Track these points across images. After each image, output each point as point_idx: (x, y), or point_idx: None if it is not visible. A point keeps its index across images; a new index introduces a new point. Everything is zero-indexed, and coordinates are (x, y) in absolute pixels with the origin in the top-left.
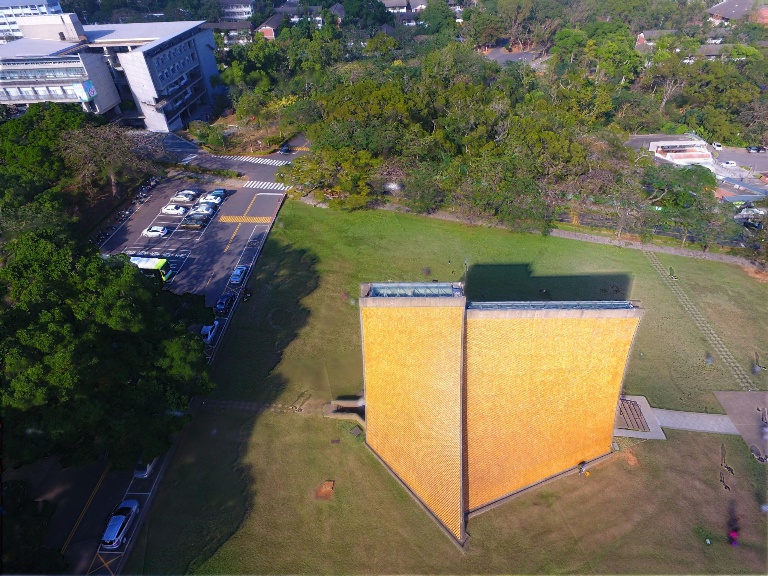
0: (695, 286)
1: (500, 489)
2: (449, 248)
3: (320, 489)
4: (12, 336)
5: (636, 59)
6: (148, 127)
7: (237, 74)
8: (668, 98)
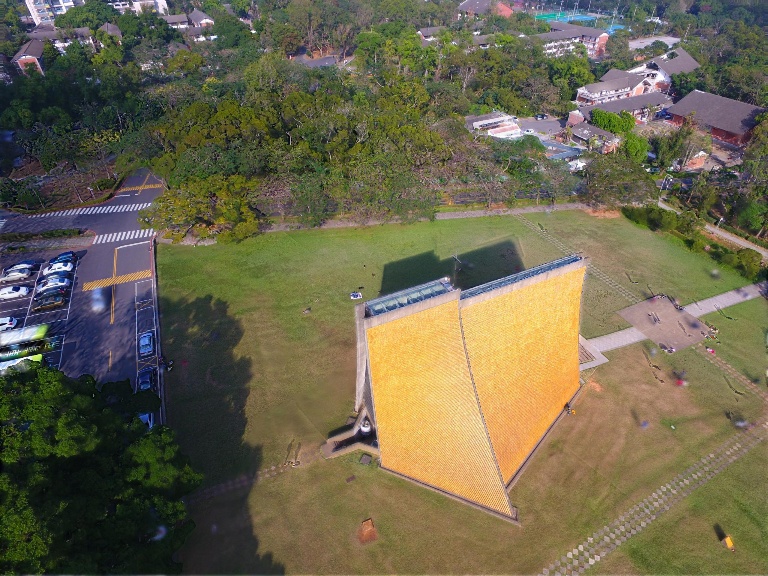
0: (562, 233)
1: (520, 455)
2: (357, 253)
3: (361, 533)
4: None
5: (433, 53)
6: None
7: (23, 114)
8: (467, 84)
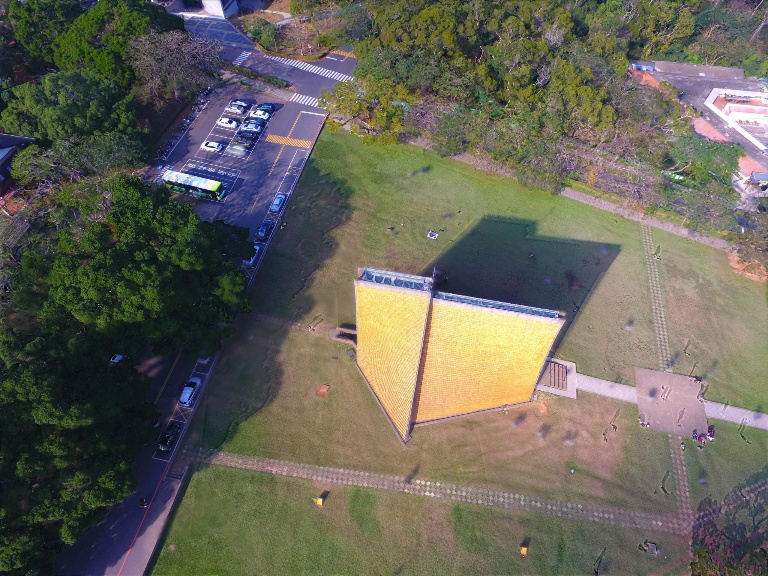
0: (672, 269)
1: (440, 413)
2: (463, 197)
3: (319, 389)
4: (119, 272)
5: None
6: (205, 7)
7: None
8: (767, 22)
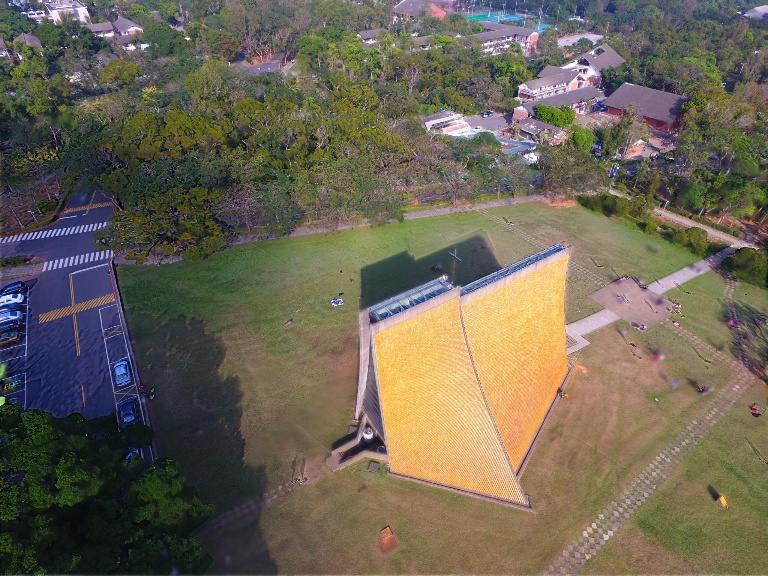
0: (526, 225)
1: (524, 443)
2: (331, 259)
3: (381, 542)
4: None
5: (378, 56)
6: None
7: None
8: (413, 85)
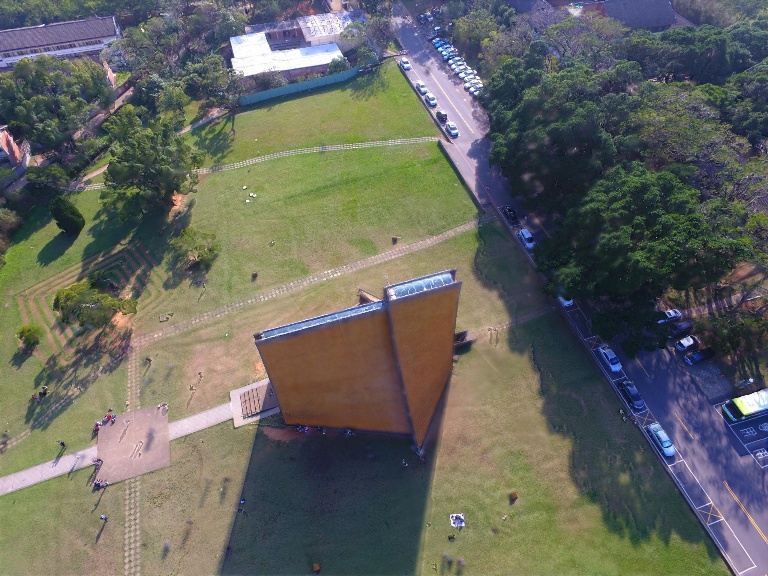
0: None
1: None
2: None
3: None
4: None
5: None
6: None
7: None
8: None
